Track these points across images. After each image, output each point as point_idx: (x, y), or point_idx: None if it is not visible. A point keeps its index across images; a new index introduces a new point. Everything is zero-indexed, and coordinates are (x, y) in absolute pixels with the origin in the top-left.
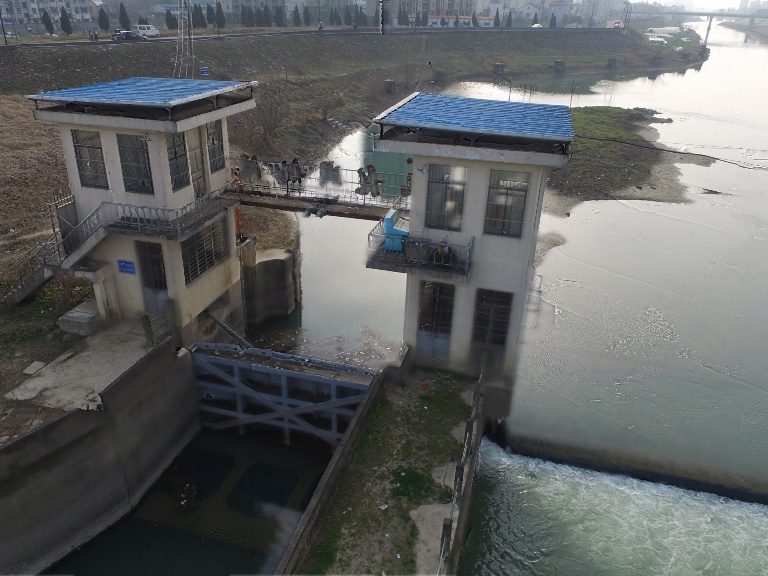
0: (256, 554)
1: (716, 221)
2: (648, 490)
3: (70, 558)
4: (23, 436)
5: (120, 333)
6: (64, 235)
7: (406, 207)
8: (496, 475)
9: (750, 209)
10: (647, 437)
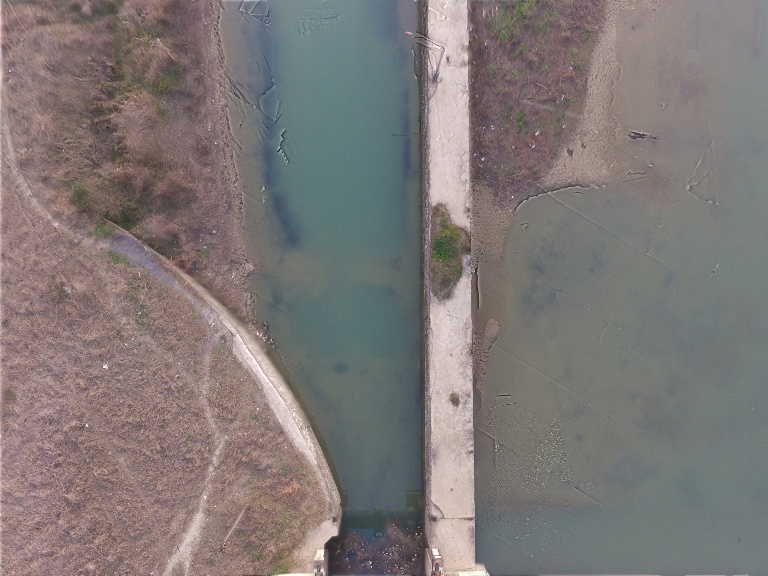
0: None
1: (626, 216)
2: None
3: None
4: None
5: None
6: None
7: None
8: None
9: (662, 176)
10: (538, 563)
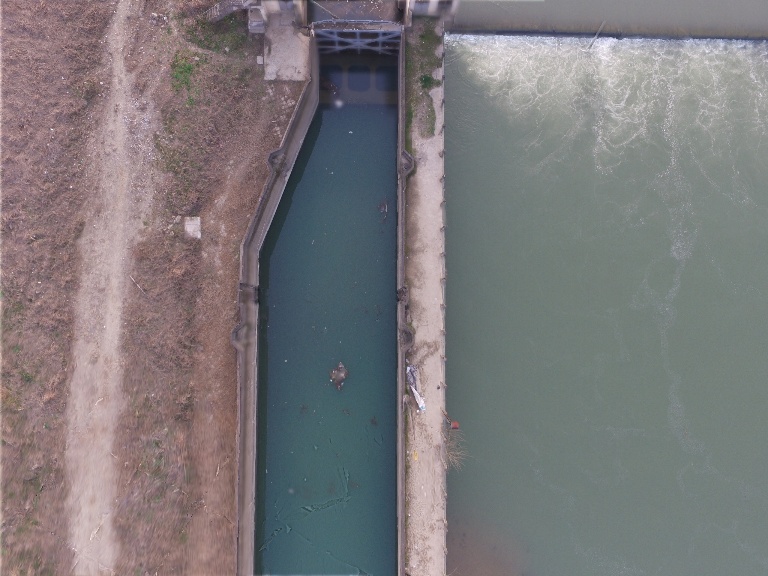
0: (369, 106)
1: None
2: (501, 39)
3: (311, 124)
4: (300, 101)
5: (277, 27)
6: None
7: None
8: (444, 47)
9: None
10: (504, 9)
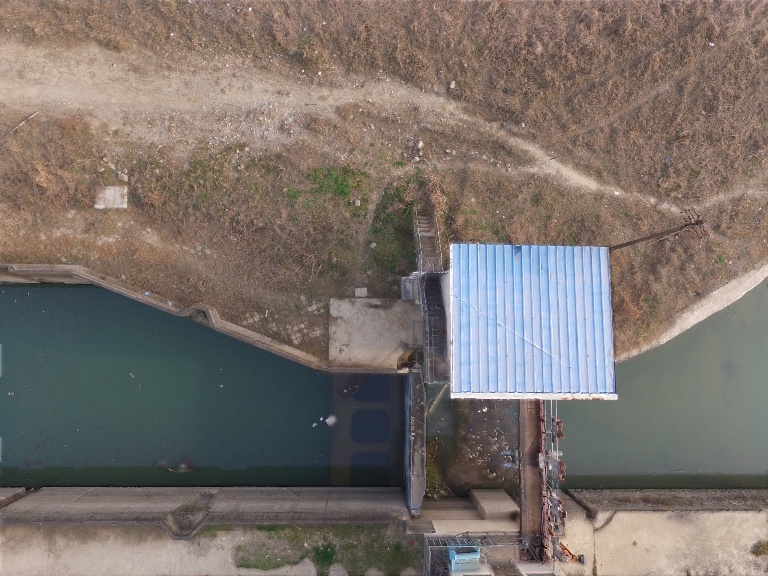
0: (329, 441)
1: None
2: None
3: None
4: None
5: (411, 317)
6: (423, 277)
7: (546, 537)
8: None
9: None
10: None
